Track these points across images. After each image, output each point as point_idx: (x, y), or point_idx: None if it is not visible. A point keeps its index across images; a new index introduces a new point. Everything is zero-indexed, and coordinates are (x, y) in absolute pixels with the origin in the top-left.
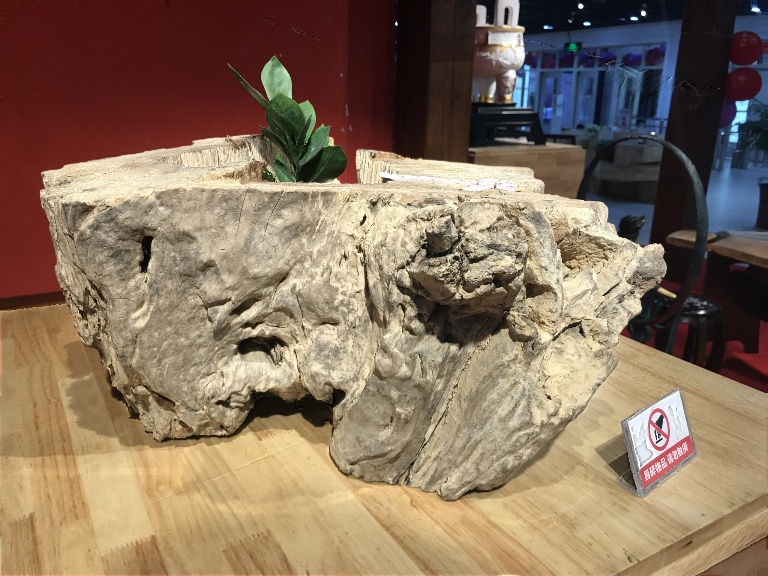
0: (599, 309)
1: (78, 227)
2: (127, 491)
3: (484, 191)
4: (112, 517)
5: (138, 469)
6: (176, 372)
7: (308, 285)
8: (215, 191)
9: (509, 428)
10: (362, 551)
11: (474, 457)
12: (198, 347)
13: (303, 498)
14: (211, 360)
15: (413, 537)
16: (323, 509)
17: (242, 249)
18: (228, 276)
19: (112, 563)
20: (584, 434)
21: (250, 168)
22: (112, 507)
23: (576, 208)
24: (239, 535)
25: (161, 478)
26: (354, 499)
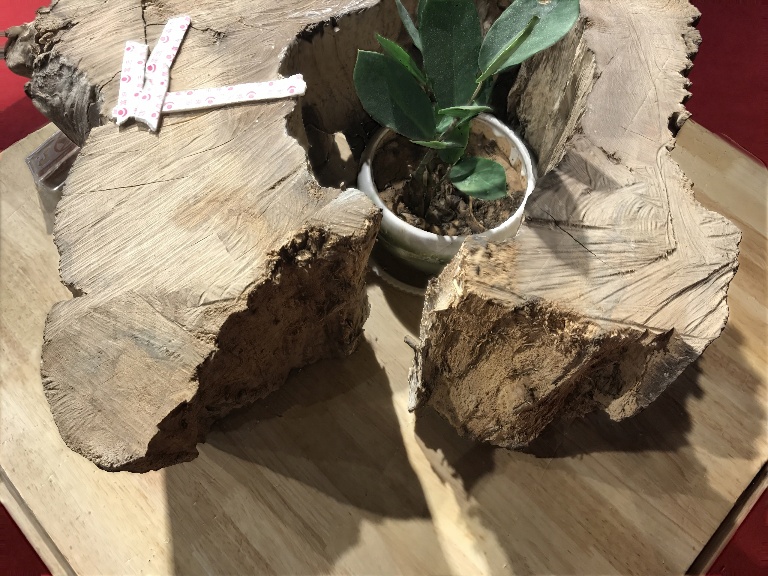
0: None
1: None
2: None
3: None
4: None
5: None
6: None
7: None
8: None
9: None
10: None
11: None
12: None
13: None
14: None
15: None
16: None
17: None
18: None
19: None
20: None
21: None
22: None
23: None
24: None
25: None
26: None
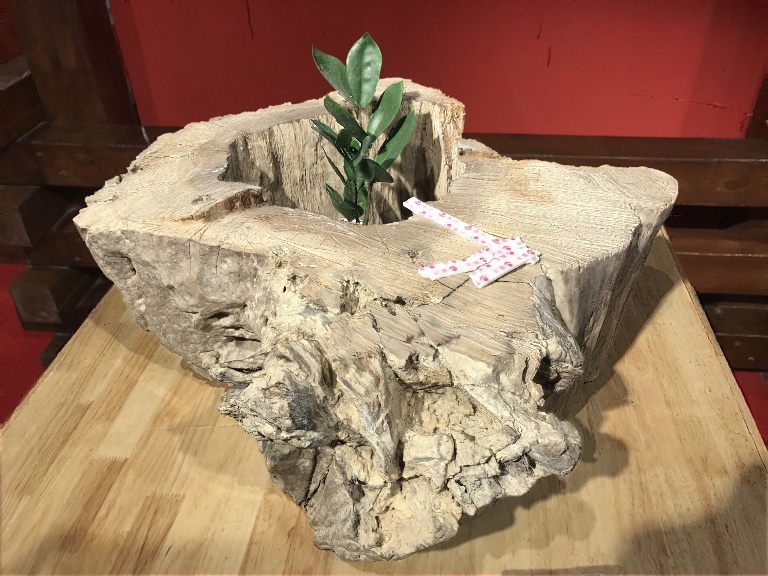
0: (458, 476)
1: (85, 238)
2: (147, 411)
3: (441, 280)
4: (122, 429)
5: (169, 393)
6: (179, 344)
7: (254, 321)
8: (162, 237)
9: (343, 532)
10: (216, 552)
11: (333, 530)
12: (191, 333)
13: (230, 479)
14: (206, 343)
15: (257, 563)
16: (231, 498)
17: (196, 281)
18: (190, 297)
19: (92, 468)
20: (517, 547)
21: (231, 200)
22: (129, 420)
23: (471, 360)
24: (166, 489)
25: (173, 409)
26: (259, 501)
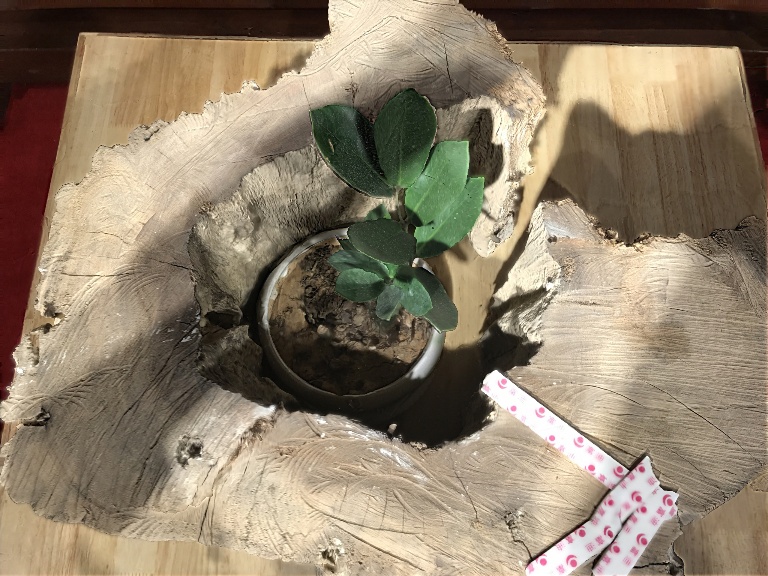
0: None
1: None
2: None
3: None
4: None
5: None
6: None
7: None
8: None
9: None
10: None
11: None
12: None
13: None
14: None
15: None
16: None
17: None
18: None
19: None
20: None
21: (237, 448)
22: None
23: None
24: None
25: None
26: None
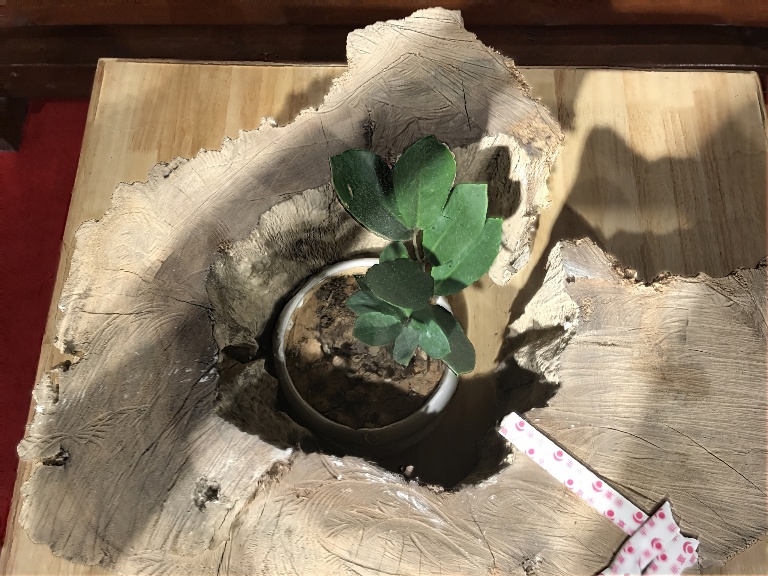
0: None
1: None
2: None
3: None
4: None
5: None
6: None
7: None
8: None
9: None
10: None
11: None
12: None
13: None
14: None
15: None
16: None
17: None
18: None
19: None
20: None
21: None
22: None
23: None
24: None
25: None
26: None
